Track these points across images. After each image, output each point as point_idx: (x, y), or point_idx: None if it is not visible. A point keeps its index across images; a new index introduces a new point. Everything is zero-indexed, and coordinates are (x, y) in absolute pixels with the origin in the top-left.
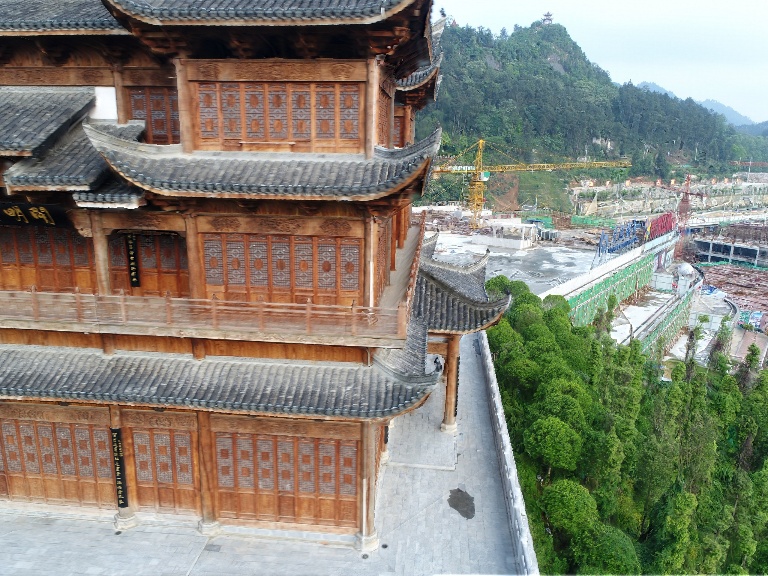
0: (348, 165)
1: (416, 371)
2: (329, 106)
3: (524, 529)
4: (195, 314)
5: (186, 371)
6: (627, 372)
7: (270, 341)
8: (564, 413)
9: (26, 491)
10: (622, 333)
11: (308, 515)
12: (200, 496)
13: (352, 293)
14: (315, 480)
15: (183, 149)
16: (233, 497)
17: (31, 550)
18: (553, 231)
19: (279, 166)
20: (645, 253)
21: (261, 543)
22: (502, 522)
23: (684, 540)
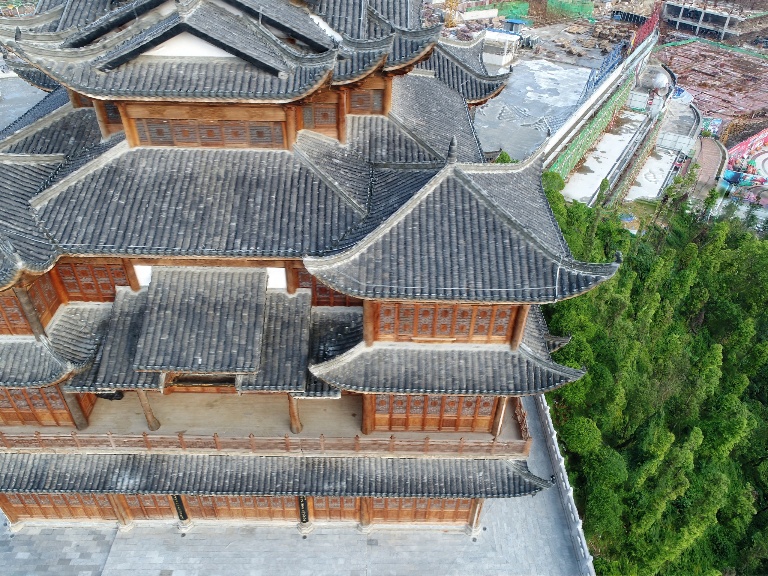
0: (498, 356)
1: None
2: (487, 317)
3: (580, 522)
4: (377, 446)
5: (361, 465)
6: (625, 302)
7: (431, 458)
8: (578, 355)
9: (230, 515)
10: (599, 175)
11: (435, 518)
12: (359, 513)
13: (485, 417)
14: (442, 503)
15: (366, 345)
16: (383, 512)
17: (253, 560)
18: (534, 38)
19: (445, 358)
20: (626, 71)
21: (403, 535)
22: (556, 497)
23: (660, 459)
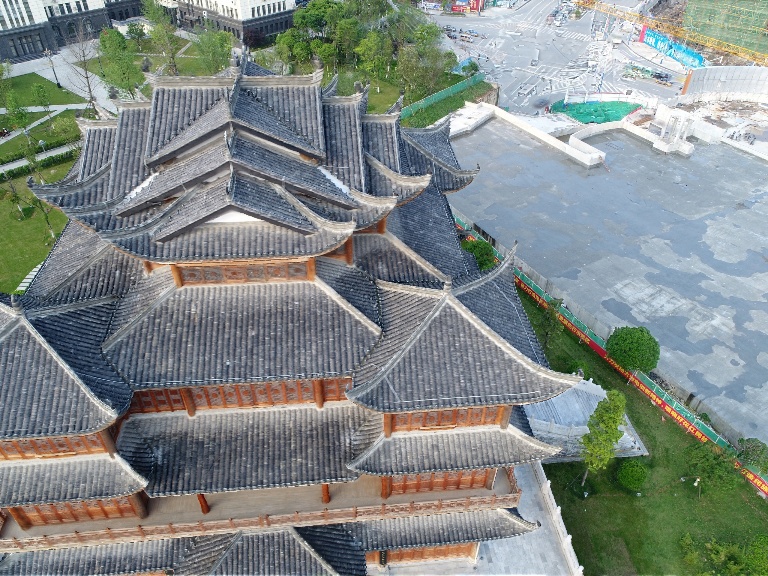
0: None
1: (63, 572)
2: None
3: None
4: None
5: None
6: None
7: None
8: None
9: None
10: None
11: None
12: None
13: None
14: None
15: None
16: None
17: None
18: None
19: None
20: None
21: None
22: None
23: None
